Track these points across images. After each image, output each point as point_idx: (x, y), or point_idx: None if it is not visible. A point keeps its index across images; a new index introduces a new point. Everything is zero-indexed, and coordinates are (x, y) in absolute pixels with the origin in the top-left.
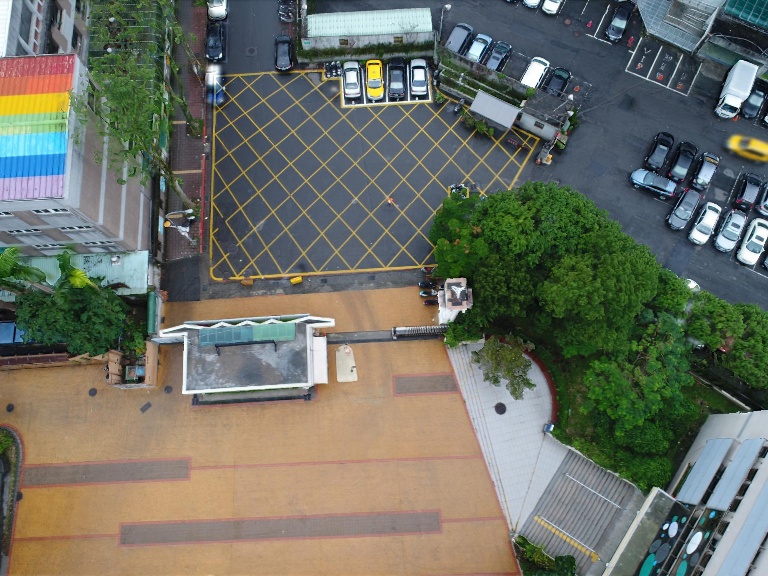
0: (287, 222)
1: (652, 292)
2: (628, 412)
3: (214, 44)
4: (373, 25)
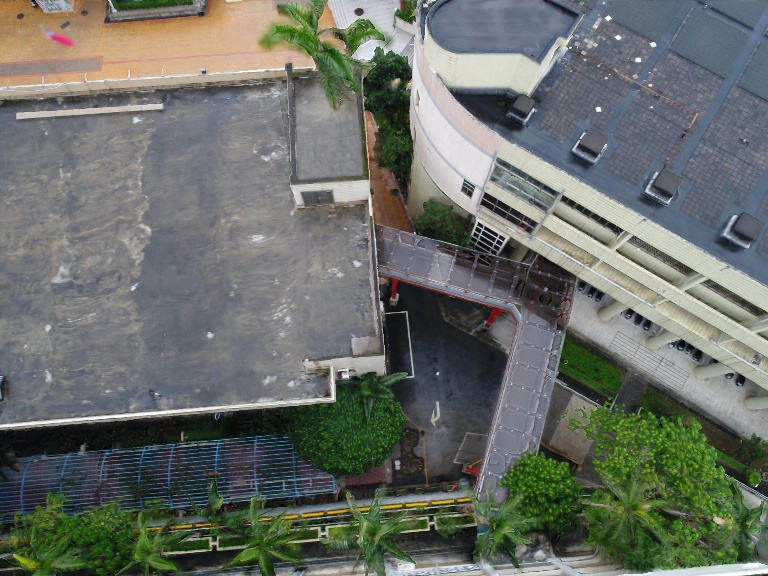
0: None
1: None
2: None
3: None
4: None
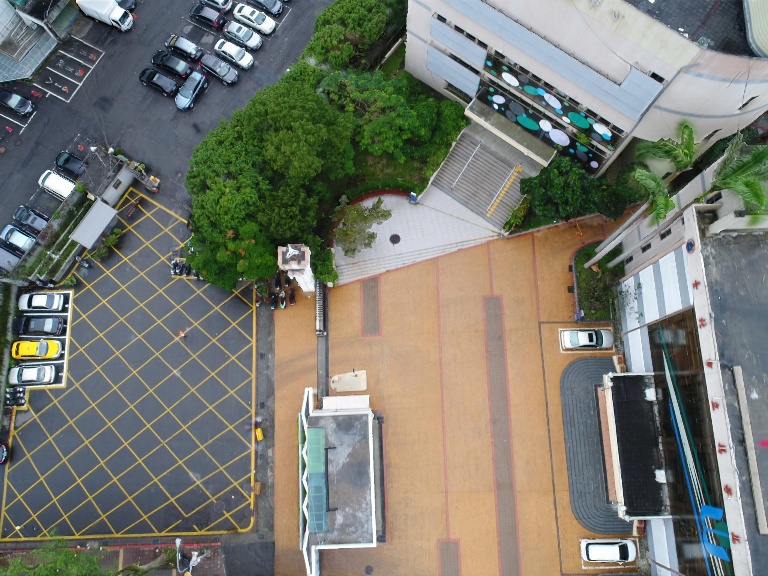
0: (194, 446)
1: None
2: (406, 121)
3: None
4: None
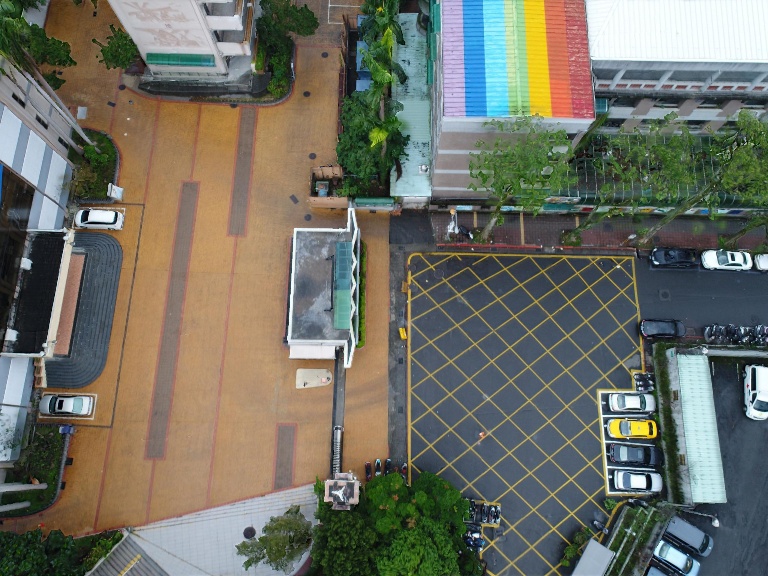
0: (465, 327)
1: None
2: None
3: (673, 257)
4: (698, 430)
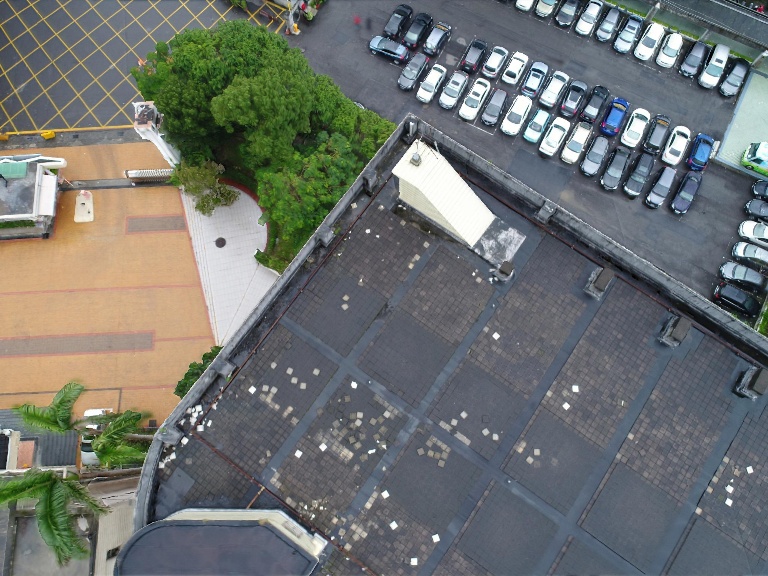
0: (46, 85)
1: (306, 103)
2: (286, 214)
3: None
4: None
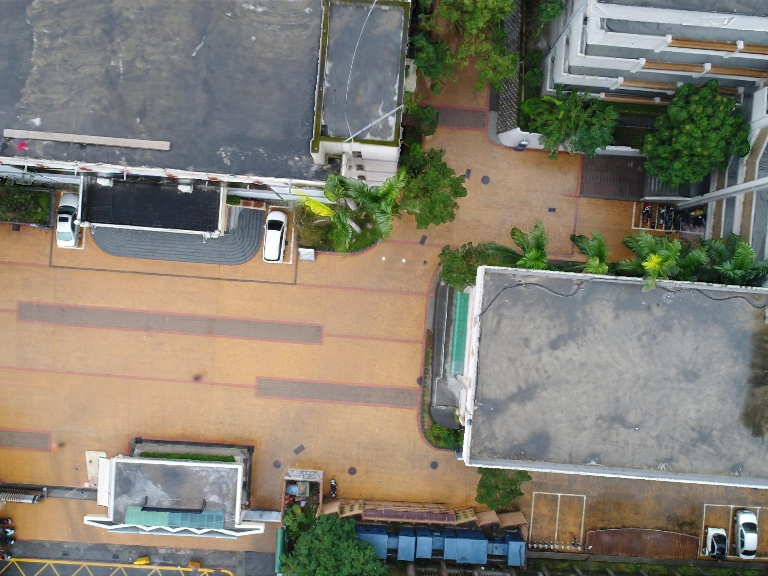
0: None
1: None
2: None
3: None
4: None
